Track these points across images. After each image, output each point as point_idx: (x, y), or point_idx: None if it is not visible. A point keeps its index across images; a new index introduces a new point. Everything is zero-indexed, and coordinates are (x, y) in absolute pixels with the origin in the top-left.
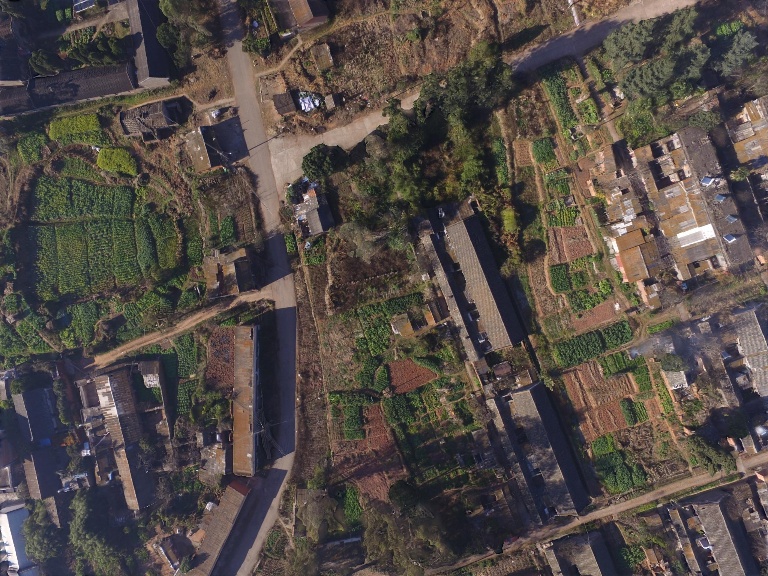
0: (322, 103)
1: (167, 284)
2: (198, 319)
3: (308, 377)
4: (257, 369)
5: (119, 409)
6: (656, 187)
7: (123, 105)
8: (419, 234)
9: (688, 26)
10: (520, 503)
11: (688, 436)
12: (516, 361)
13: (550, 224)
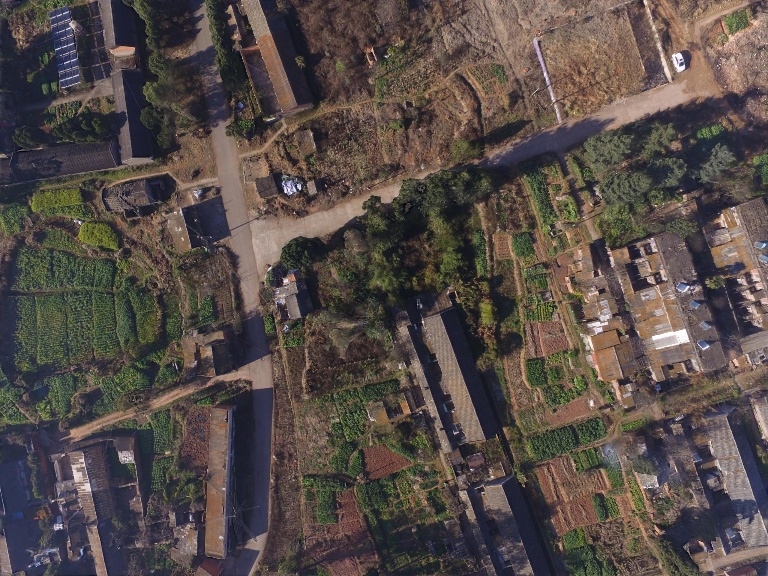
0: (304, 187)
1: (145, 359)
2: (175, 396)
3: (283, 458)
4: (232, 451)
5: (93, 485)
6: (632, 289)
7: (106, 180)
8: (397, 324)
9: (666, 140)
10: None
11: (658, 535)
12: (490, 454)
13: (527, 318)
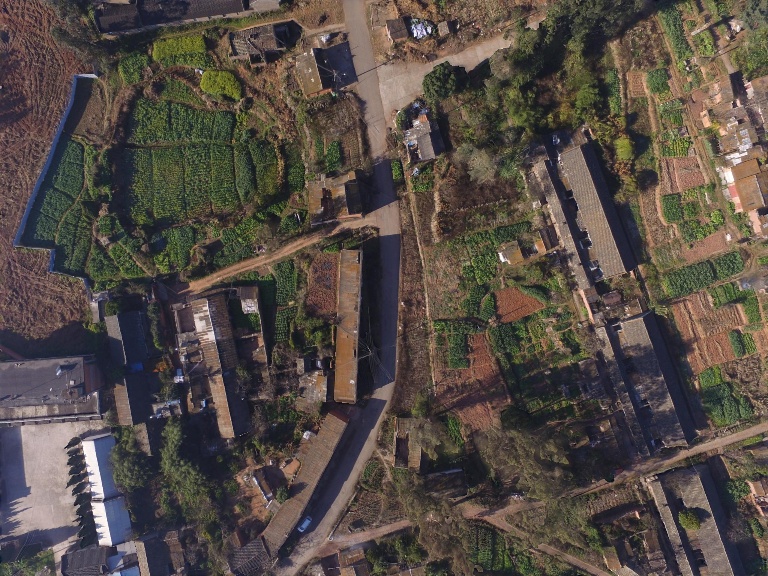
0: (434, 30)
1: (266, 210)
2: (298, 245)
3: (411, 306)
4: (361, 295)
5: (217, 334)
6: None
7: (229, 28)
8: (533, 160)
9: None
10: (625, 436)
11: None
12: (627, 290)
13: (663, 154)
